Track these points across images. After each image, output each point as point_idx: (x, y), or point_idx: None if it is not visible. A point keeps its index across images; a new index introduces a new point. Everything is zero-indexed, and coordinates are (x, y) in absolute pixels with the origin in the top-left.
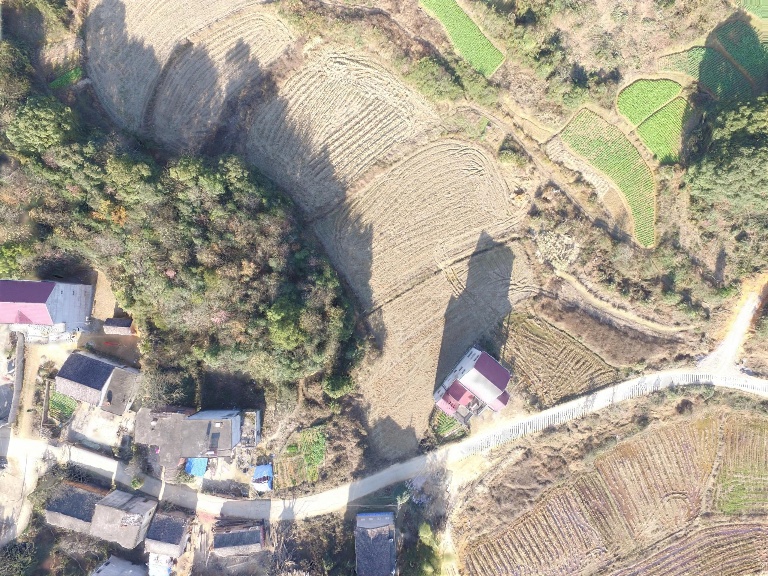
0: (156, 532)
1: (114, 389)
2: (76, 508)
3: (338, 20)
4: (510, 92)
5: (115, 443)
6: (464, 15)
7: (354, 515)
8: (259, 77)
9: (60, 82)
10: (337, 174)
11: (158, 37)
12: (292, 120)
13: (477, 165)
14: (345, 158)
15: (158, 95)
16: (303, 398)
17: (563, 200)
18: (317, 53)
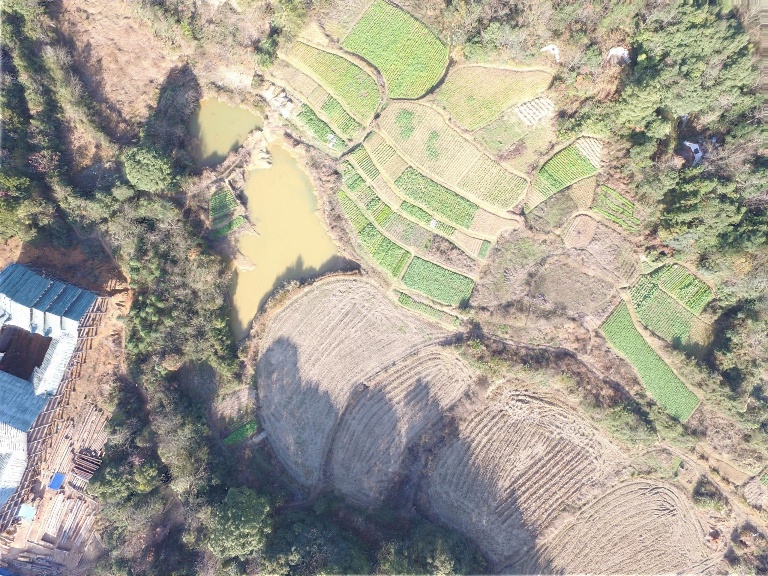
0: None
1: None
2: None
3: (526, 368)
4: (707, 438)
5: None
6: (656, 356)
7: None
8: (441, 423)
9: (235, 438)
10: (525, 521)
11: (333, 382)
12: (475, 464)
13: (669, 505)
14: (533, 503)
15: (335, 443)
16: None
17: (762, 544)
18: (498, 392)
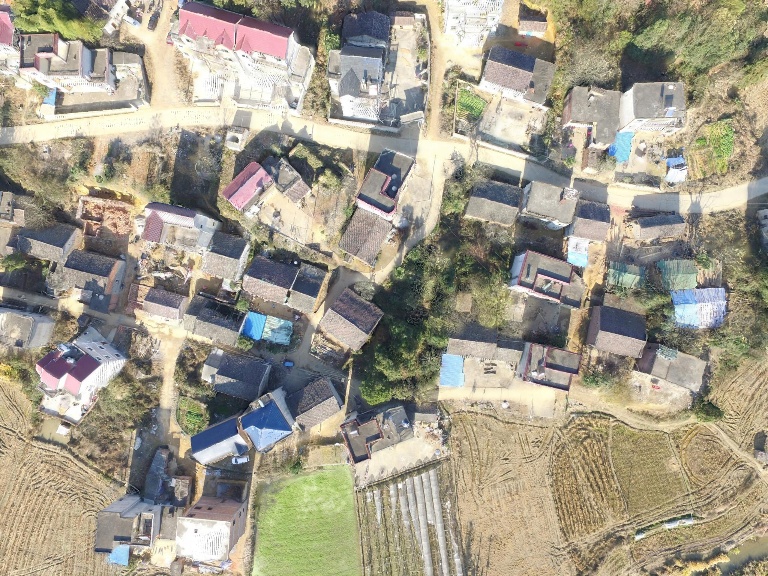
0: (585, 213)
1: (536, 79)
2: (499, 196)
3: None
4: None
5: (524, 142)
6: None
7: (754, 212)
8: None
9: None
10: None
11: None
12: None
13: None
14: None
15: None
16: (708, 94)
17: None
18: None
